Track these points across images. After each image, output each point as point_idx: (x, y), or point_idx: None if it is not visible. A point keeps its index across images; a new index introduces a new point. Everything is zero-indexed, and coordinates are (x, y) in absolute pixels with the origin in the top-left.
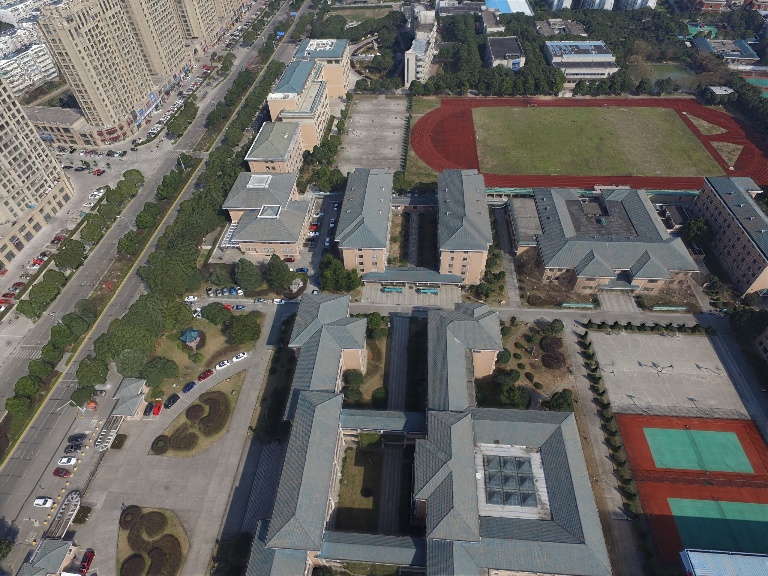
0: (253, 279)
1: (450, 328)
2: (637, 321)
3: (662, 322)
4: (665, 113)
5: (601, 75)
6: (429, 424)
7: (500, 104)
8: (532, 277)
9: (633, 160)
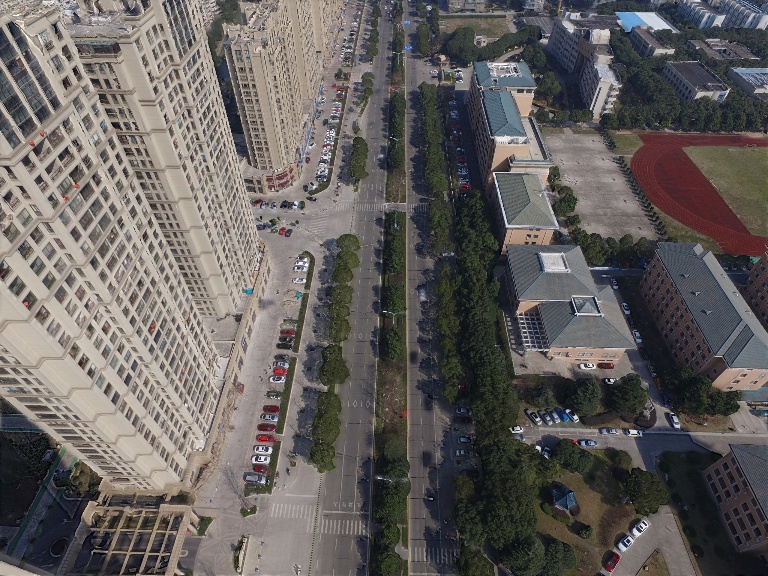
0: (597, 403)
1: None
2: None
3: None
4: None
5: None
6: None
7: (710, 143)
8: None
9: None
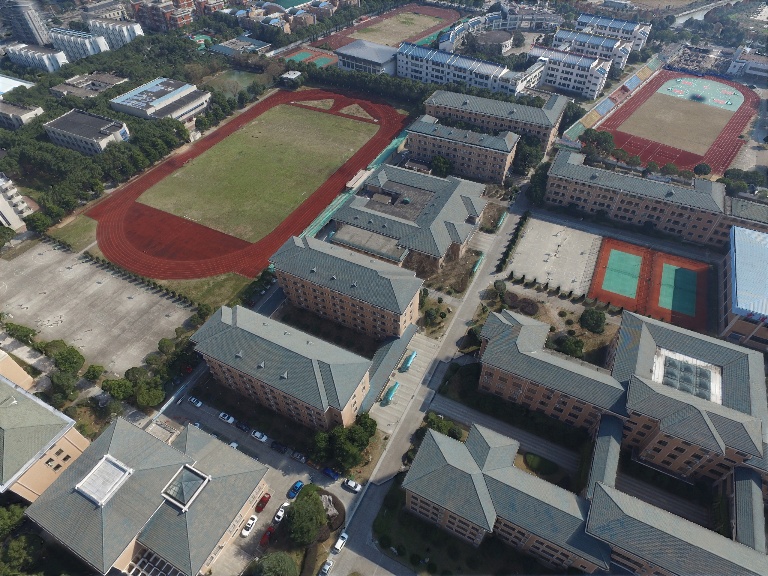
0: (290, 567)
1: (522, 350)
2: (504, 242)
3: (510, 230)
4: (283, 109)
5: (201, 105)
6: (644, 412)
7: (155, 179)
8: (431, 276)
9: (326, 152)
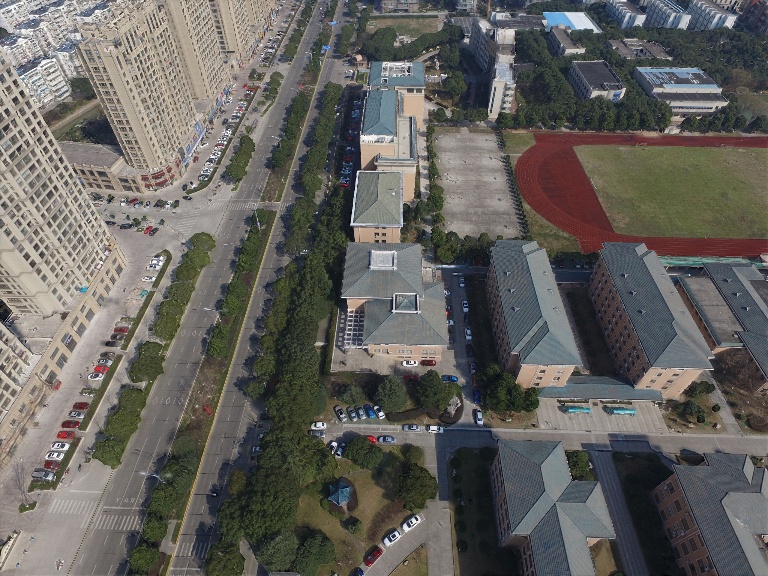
0: (400, 399)
1: (727, 504)
2: None
3: None
4: None
5: (708, 109)
6: None
7: (603, 142)
8: (739, 387)
9: None
